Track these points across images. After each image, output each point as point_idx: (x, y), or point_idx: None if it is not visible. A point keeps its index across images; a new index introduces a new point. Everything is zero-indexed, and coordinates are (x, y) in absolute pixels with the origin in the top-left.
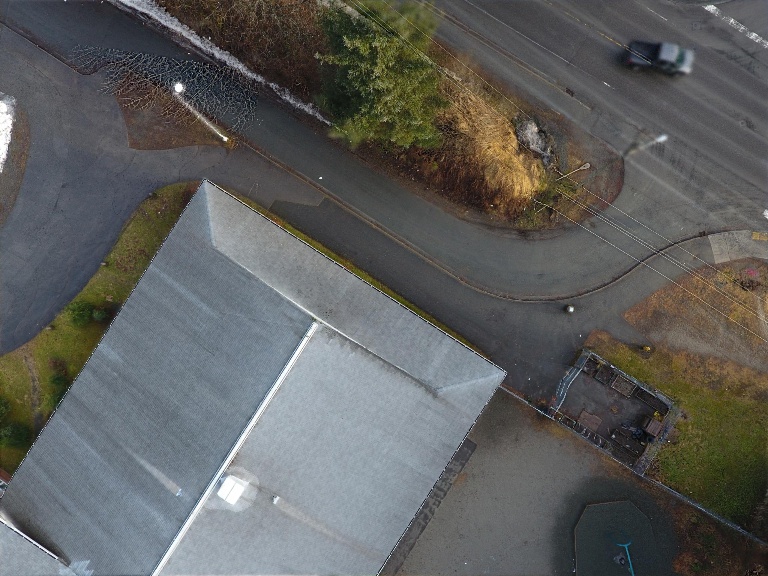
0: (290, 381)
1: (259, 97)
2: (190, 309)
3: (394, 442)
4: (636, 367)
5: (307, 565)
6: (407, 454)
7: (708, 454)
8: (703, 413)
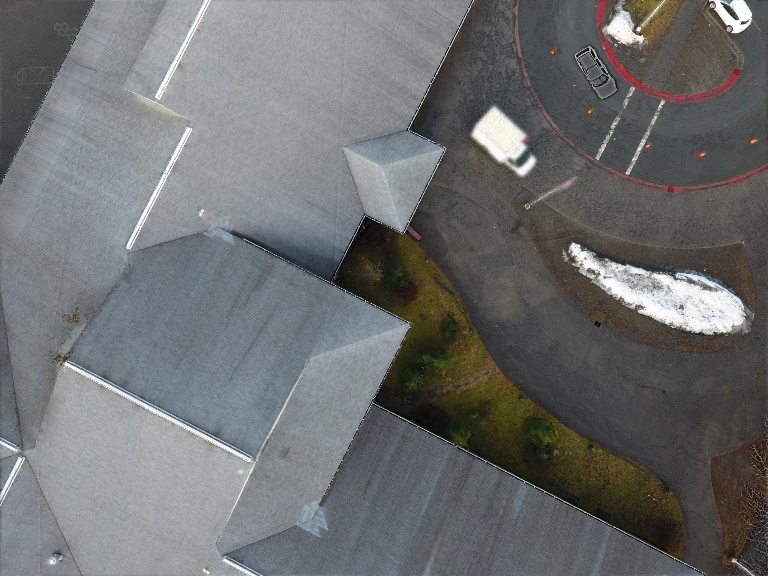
0: None
1: None
2: None
3: None
4: None
5: None
6: None
7: None
8: None
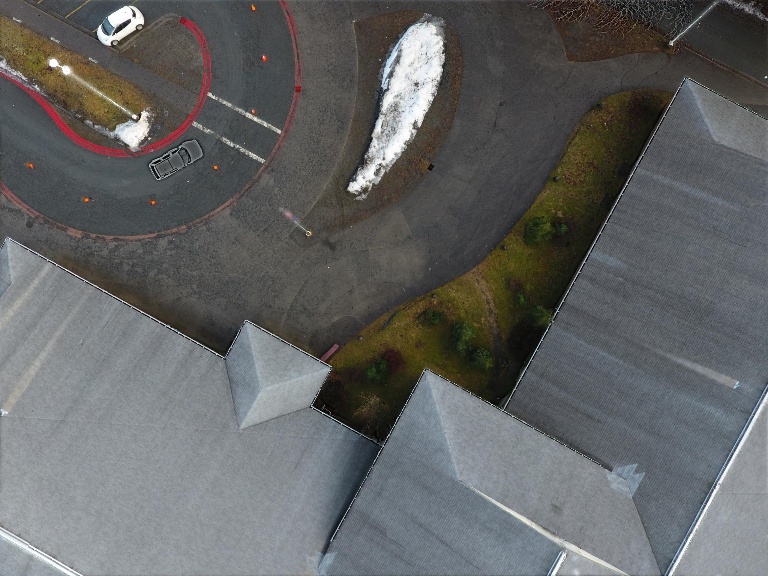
0: None
1: (694, 0)
2: (702, 206)
3: None
4: None
5: None
6: None
7: None
8: None
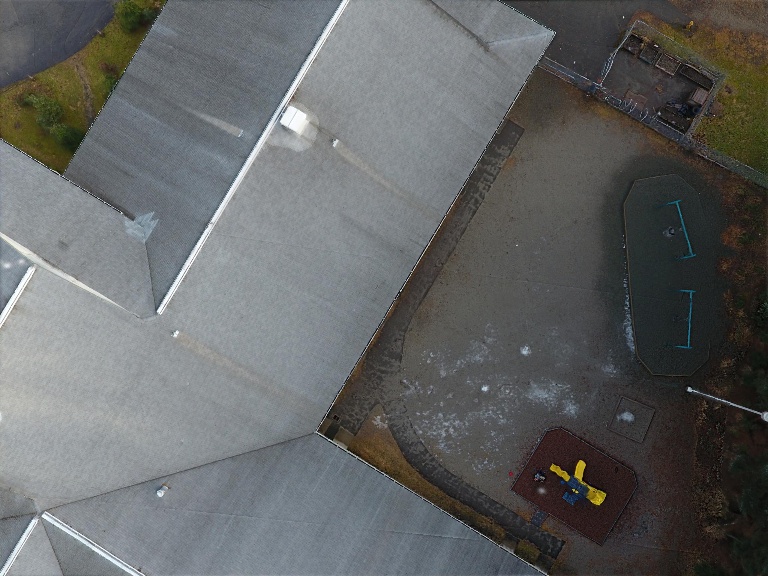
0: (347, 17)
1: None
2: None
3: (448, 94)
4: (679, 46)
5: (366, 216)
6: (460, 109)
7: (753, 127)
8: (747, 87)
